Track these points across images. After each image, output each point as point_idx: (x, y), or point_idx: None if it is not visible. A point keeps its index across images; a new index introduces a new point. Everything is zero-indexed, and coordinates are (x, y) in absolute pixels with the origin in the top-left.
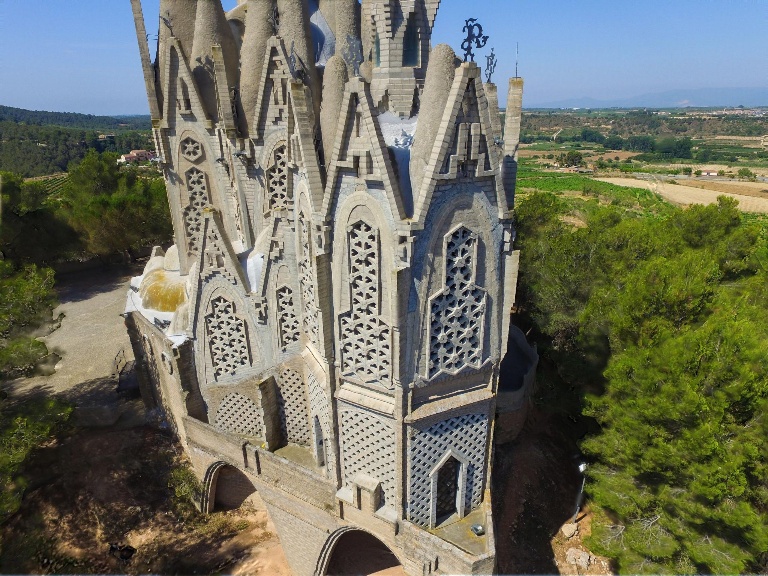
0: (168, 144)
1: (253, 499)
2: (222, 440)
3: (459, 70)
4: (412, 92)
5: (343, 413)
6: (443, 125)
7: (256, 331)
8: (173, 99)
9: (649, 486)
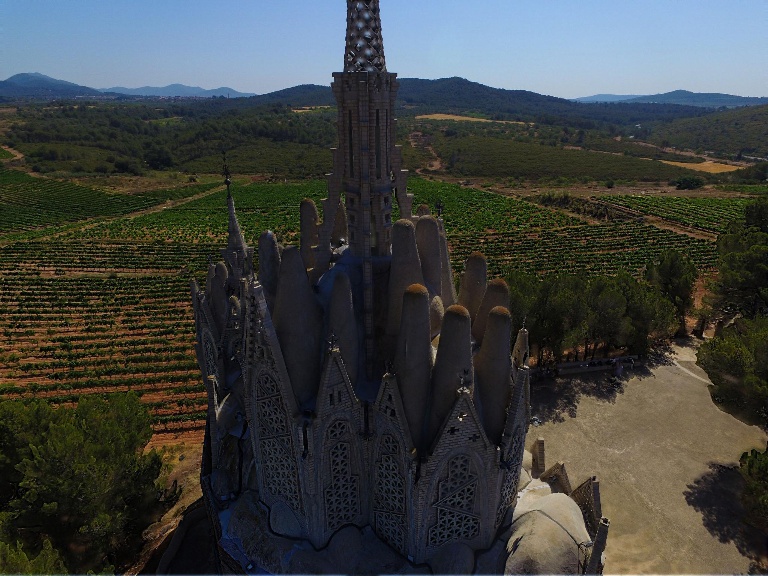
0: None
1: None
2: None
3: None
4: None
5: None
6: None
7: None
8: None
9: None
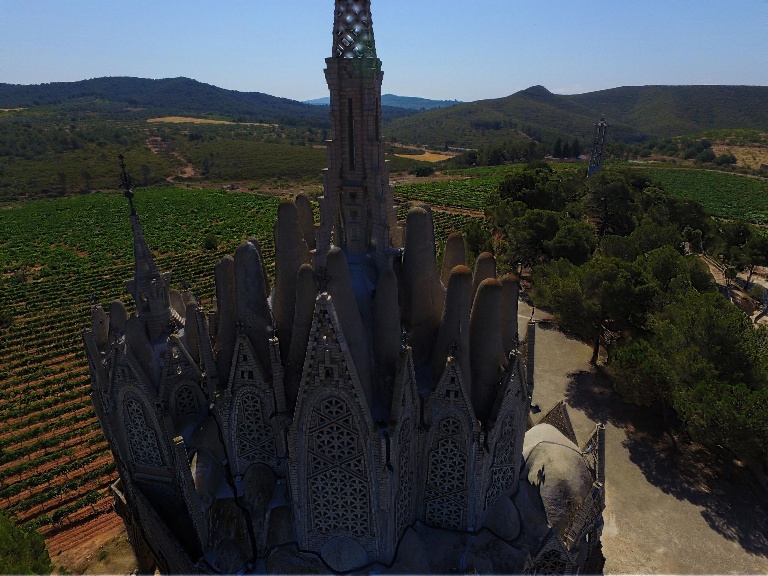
0: None
1: None
2: None
3: None
4: None
5: None
6: None
7: None
8: None
9: None
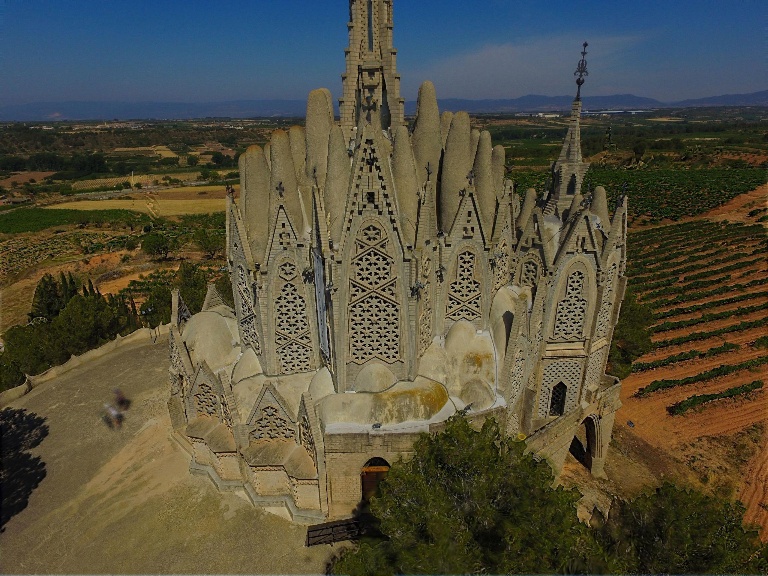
0: None
1: None
2: None
3: (625, 198)
4: None
5: None
6: None
7: None
8: None
9: None
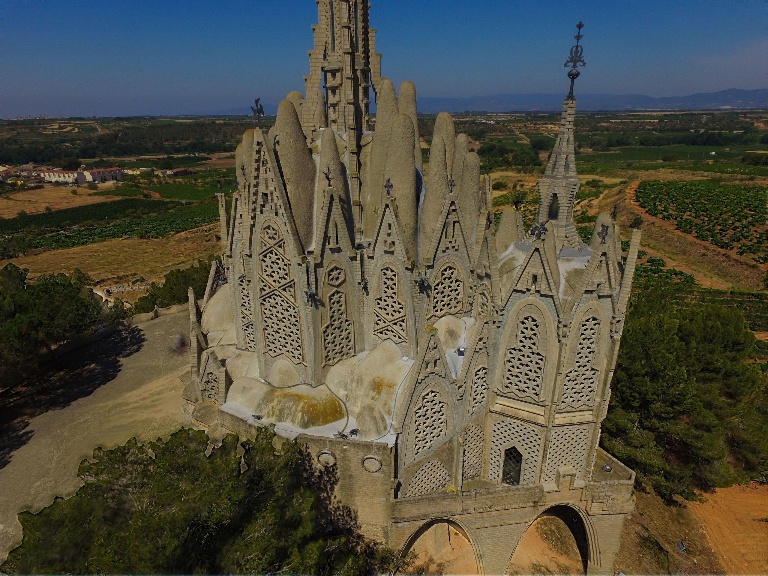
0: (316, 275)
1: (415, 547)
2: (438, 501)
3: (637, 233)
4: (576, 234)
5: (553, 434)
6: (631, 260)
7: (454, 407)
8: (325, 237)
9: (633, 410)
